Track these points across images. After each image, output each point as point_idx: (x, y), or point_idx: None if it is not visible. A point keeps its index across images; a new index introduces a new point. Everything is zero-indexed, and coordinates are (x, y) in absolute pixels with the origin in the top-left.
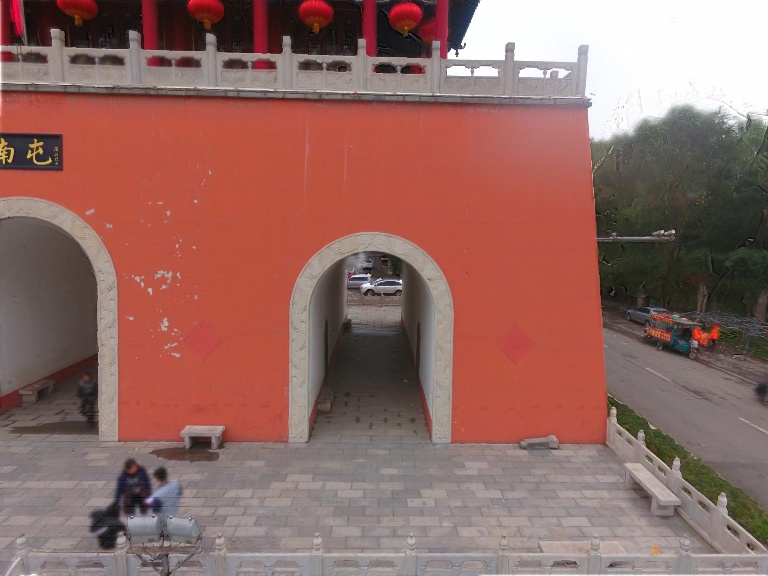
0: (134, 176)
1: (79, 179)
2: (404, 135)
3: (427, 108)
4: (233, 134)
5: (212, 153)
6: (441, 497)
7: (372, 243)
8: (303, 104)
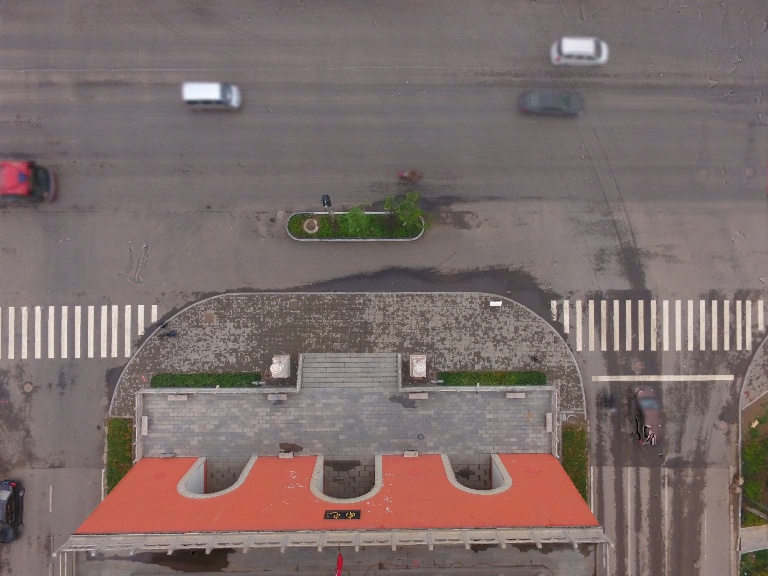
0: None
1: None
2: (169, 524)
3: None
4: None
5: None
6: (208, 425)
7: None
8: None
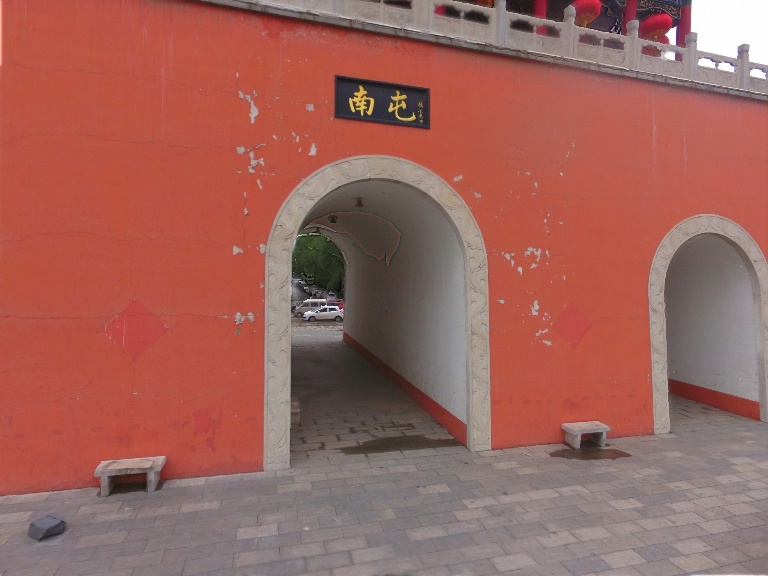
0: (502, 142)
1: (446, 141)
2: (726, 125)
3: (742, 103)
4: (593, 108)
5: (574, 125)
6: None
7: (710, 225)
8: (649, 86)
